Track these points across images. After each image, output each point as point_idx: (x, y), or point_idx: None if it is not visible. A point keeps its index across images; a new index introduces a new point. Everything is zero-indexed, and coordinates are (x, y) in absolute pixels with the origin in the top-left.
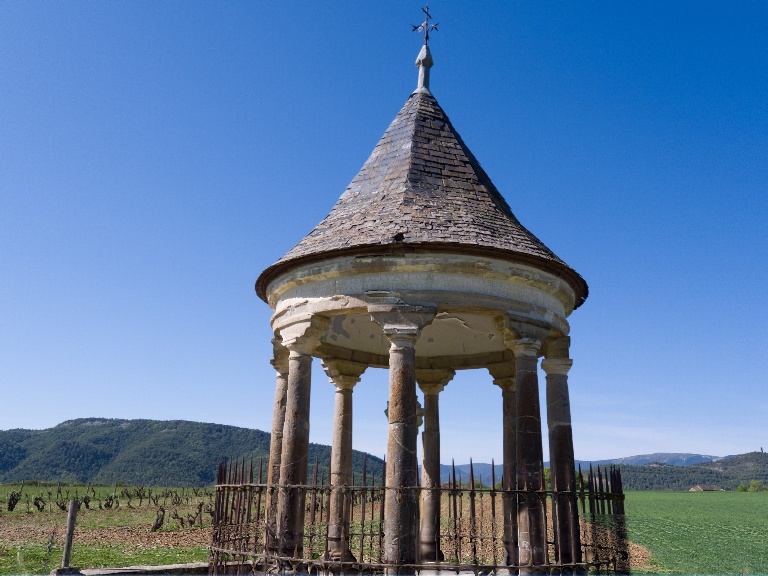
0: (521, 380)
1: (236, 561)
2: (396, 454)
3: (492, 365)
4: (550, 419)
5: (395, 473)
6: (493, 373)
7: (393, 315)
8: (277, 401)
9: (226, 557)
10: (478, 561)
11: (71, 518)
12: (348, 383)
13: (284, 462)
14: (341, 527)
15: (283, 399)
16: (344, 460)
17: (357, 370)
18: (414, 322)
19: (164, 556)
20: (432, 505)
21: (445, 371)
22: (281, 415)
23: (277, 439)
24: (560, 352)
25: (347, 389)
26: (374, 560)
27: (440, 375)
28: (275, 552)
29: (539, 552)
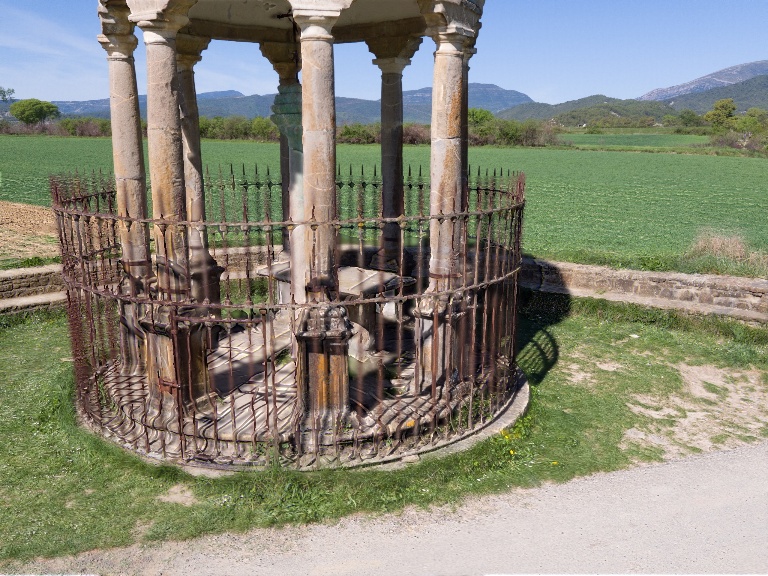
0: (464, 90)
1: None
2: (458, 171)
3: (273, 44)
4: (393, 119)
5: (457, 191)
6: (273, 54)
7: (460, 10)
8: (165, 83)
9: (317, 312)
10: None
11: None
12: (135, 48)
13: (327, 184)
14: (148, 247)
15: (174, 80)
16: (142, 160)
17: (133, 27)
18: (470, 23)
19: None
20: (203, 205)
21: (207, 41)
22: (175, 105)
23: (174, 142)
24: (411, 53)
25: (133, 57)
26: None
27: (201, 45)
28: (324, 292)
29: None
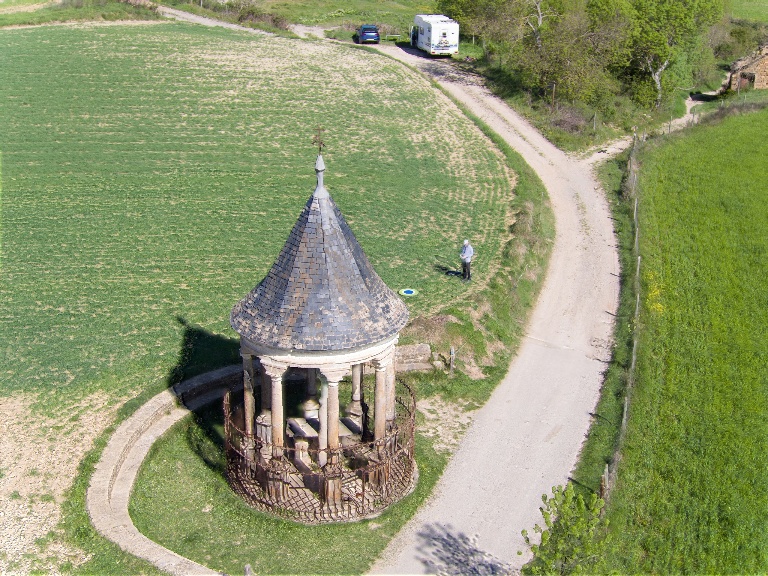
0: None
1: (147, 556)
2: None
3: None
4: None
5: None
6: None
7: None
8: None
9: None
10: None
11: None
12: None
13: None
14: None
15: None
16: None
17: None
18: None
19: None
20: None
21: None
22: None
23: None
24: None
25: None
26: (5, 524)
27: None
28: None
29: (362, 393)
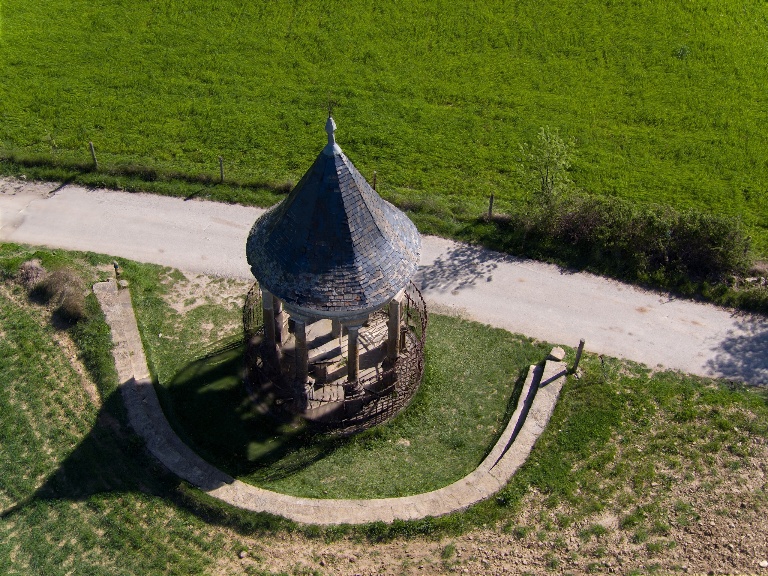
0: None
1: (530, 442)
2: None
3: None
4: None
5: None
6: None
7: None
8: None
9: None
10: (375, 525)
11: None
12: None
13: None
14: None
15: None
16: None
17: None
18: None
19: (637, 475)
20: None
21: None
22: None
23: None
24: None
25: None
26: (498, 574)
27: None
28: None
29: None
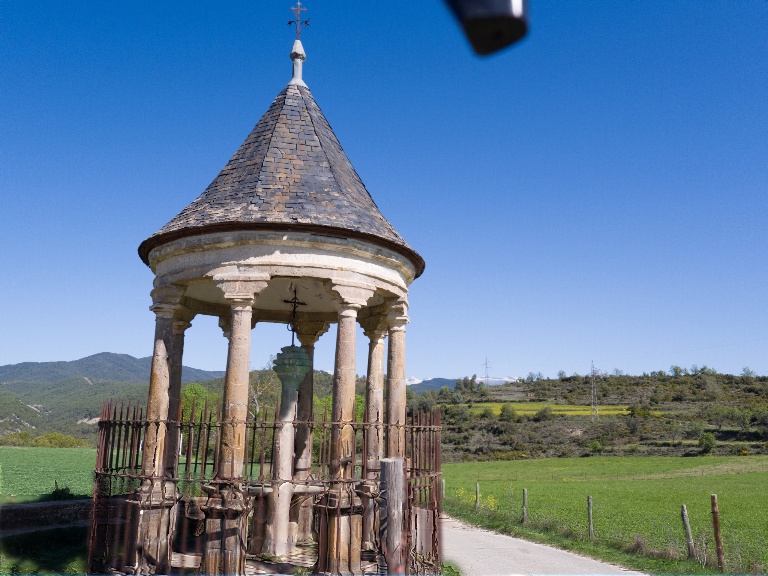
0: None
1: None
2: None
3: None
4: None
5: None
6: None
7: None
8: None
9: None
10: None
11: (404, 509)
12: None
13: None
14: None
15: None
16: None
17: None
18: None
19: None
20: None
21: None
22: None
23: None
24: None
25: None
26: None
27: None
28: None
29: None
